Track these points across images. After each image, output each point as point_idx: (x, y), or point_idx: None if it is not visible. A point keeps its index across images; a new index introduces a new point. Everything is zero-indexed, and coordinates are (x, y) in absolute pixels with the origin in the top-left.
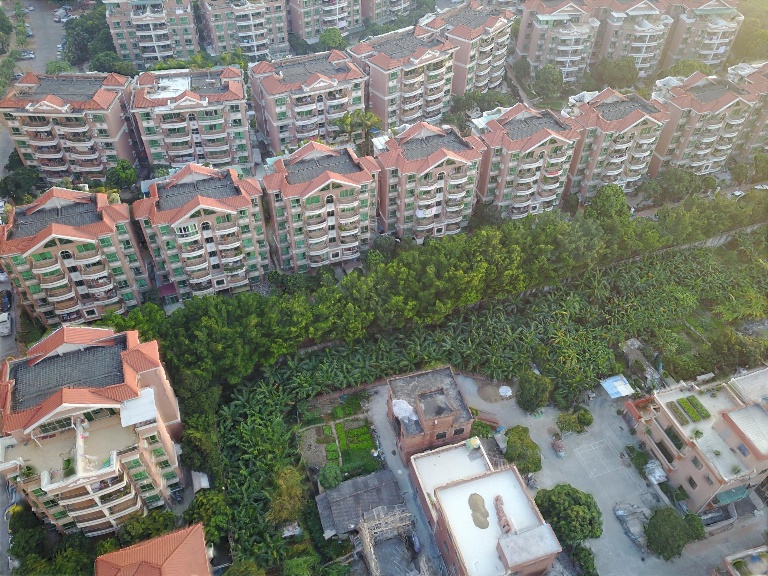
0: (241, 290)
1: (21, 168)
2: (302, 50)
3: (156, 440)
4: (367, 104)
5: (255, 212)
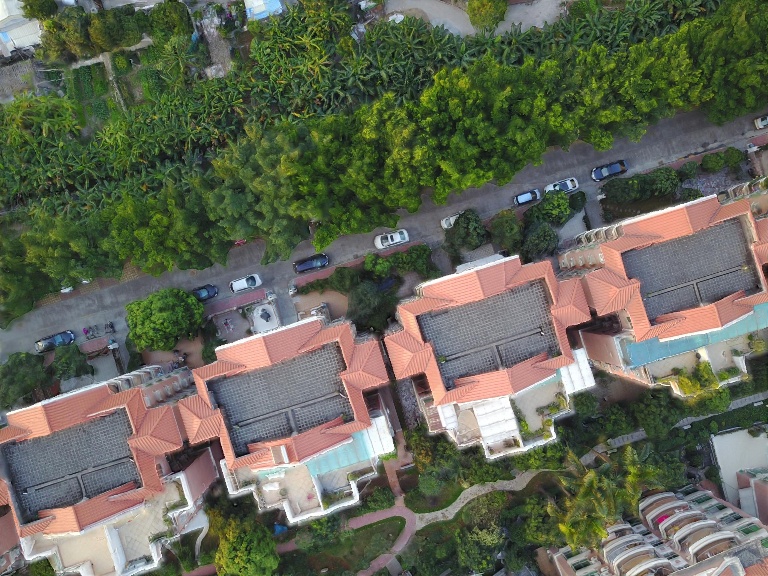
0: None
1: None
2: None
3: None
4: None
5: None
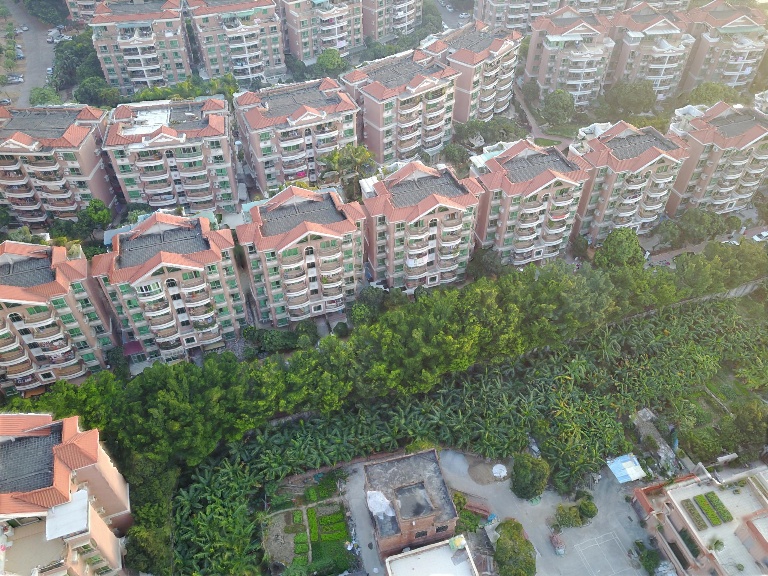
0: (214, 346)
1: None
2: (299, 72)
3: (90, 548)
4: (362, 134)
5: (227, 265)
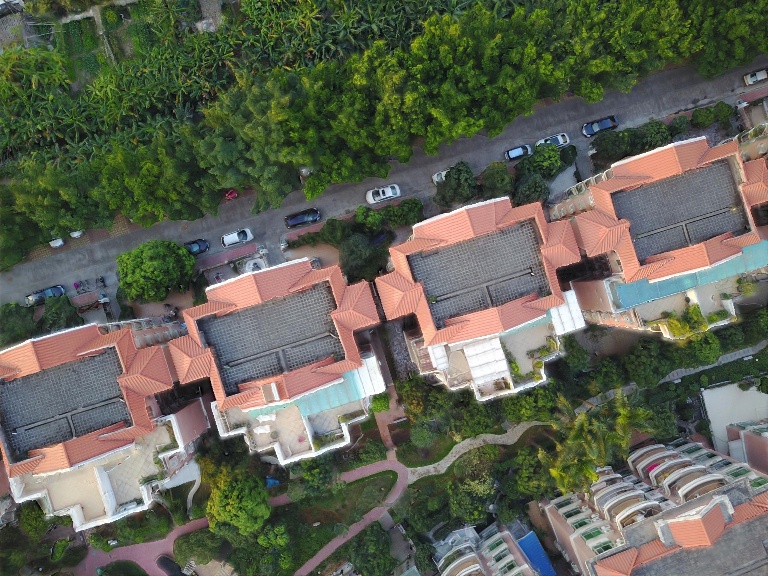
0: None
1: None
2: None
3: None
4: None
5: None
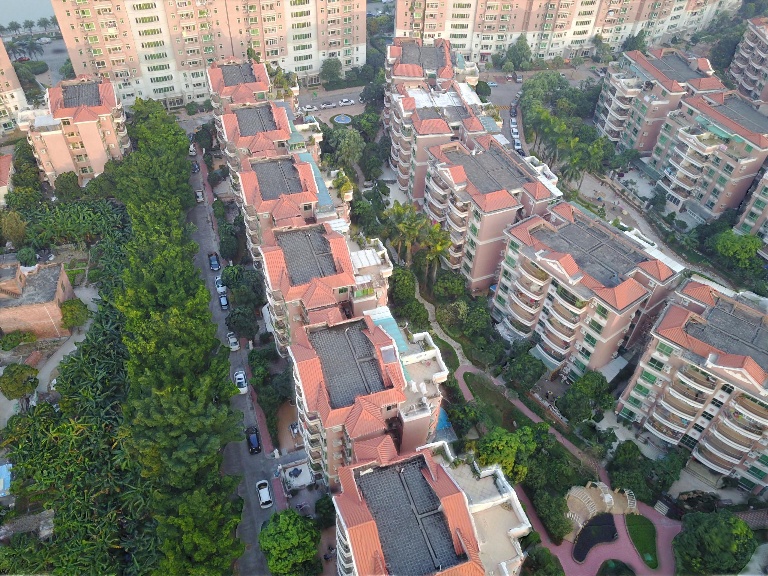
0: (242, 211)
1: (380, 84)
2: None
3: None
4: None
5: None
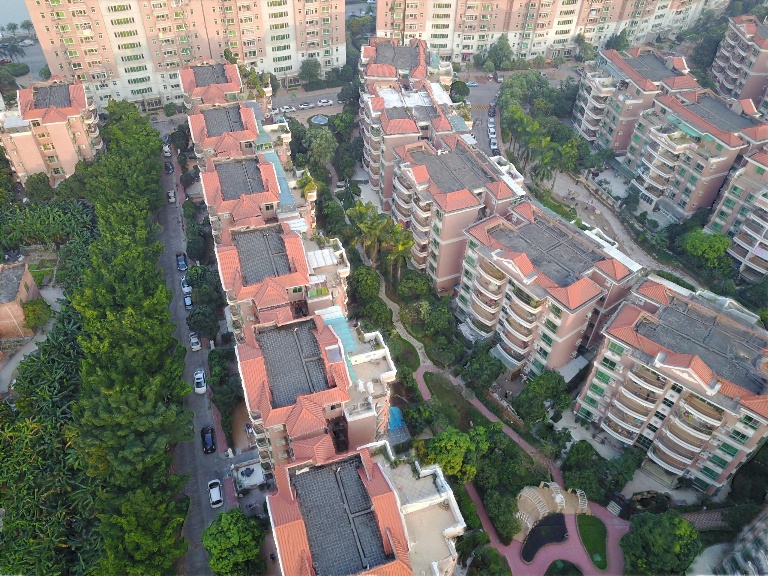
0: None
1: (357, 85)
2: None
3: (15, 146)
4: None
5: None
